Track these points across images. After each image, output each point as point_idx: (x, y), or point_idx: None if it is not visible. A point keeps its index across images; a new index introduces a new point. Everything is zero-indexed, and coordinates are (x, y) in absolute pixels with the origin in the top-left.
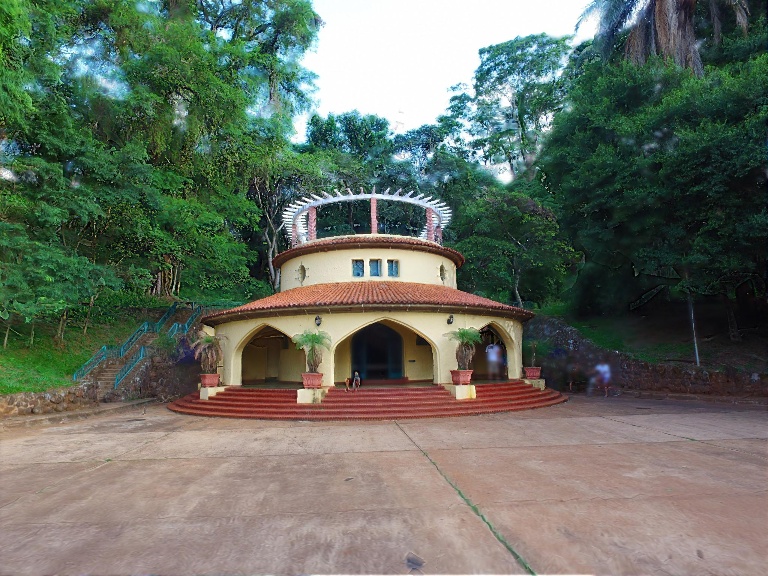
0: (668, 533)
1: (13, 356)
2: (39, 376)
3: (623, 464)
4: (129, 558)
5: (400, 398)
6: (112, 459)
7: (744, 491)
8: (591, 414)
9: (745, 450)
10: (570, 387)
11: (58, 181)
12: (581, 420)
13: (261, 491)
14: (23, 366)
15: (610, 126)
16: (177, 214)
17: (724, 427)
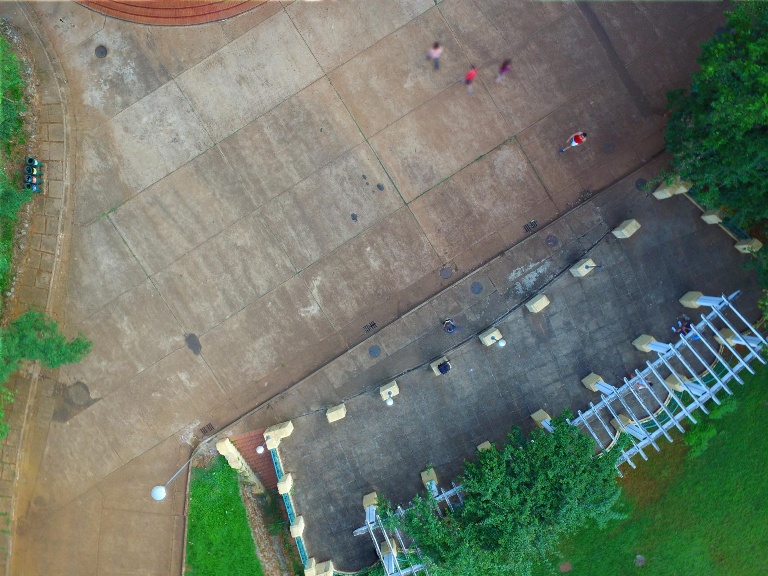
0: (411, 140)
1: None
2: None
3: (404, 69)
4: (313, 203)
5: None
6: (214, 142)
7: (435, 94)
8: None
9: (451, 22)
10: None
11: None
12: None
13: (304, 153)
14: None
15: None
16: None
17: None
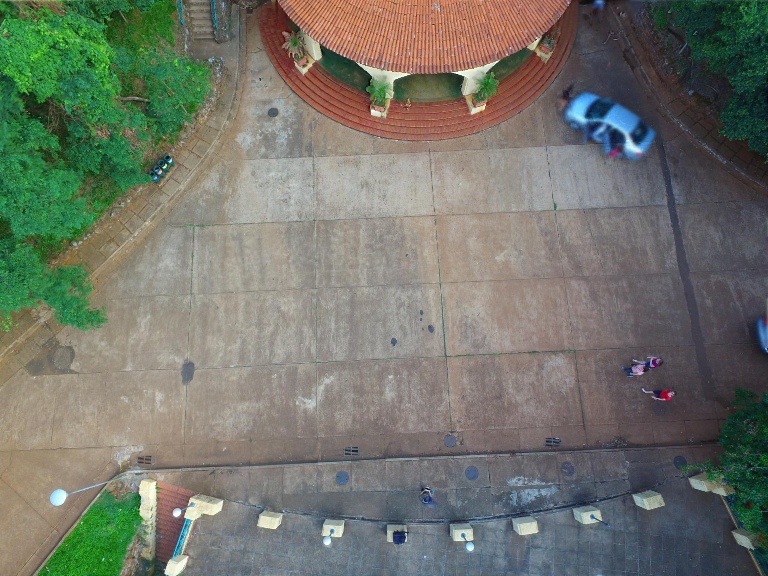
0: (479, 304)
1: (137, 26)
2: (170, 45)
3: (503, 245)
4: (365, 310)
5: (435, 119)
6: (315, 219)
7: (520, 278)
8: (545, 138)
9: (561, 229)
10: None
11: None
12: (530, 156)
13: (381, 265)
14: (152, 37)
15: None
16: None
17: (589, 184)
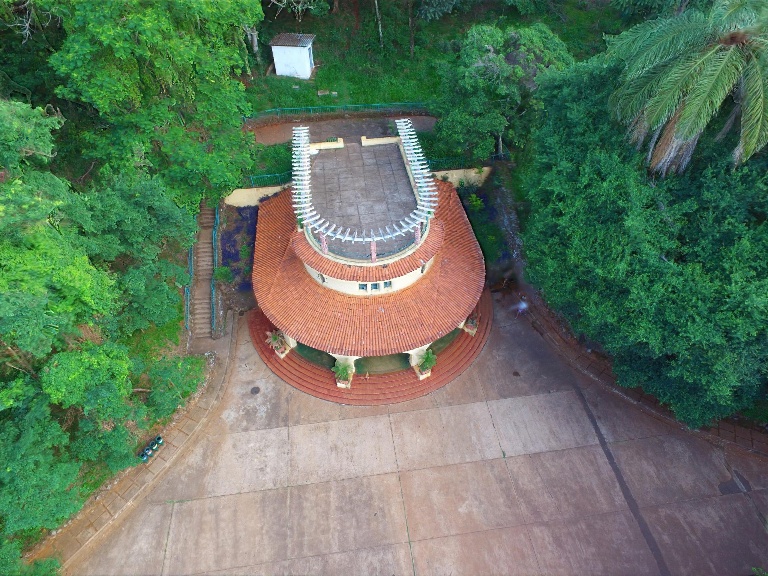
0: (450, 562)
1: (151, 334)
2: (175, 345)
3: (463, 496)
4: None
5: None
6: (288, 485)
7: (484, 529)
8: (484, 394)
9: (513, 476)
10: (504, 284)
11: (114, 243)
12: (474, 411)
13: (352, 528)
14: (162, 341)
15: (569, 232)
16: (184, 162)
17: (529, 431)
